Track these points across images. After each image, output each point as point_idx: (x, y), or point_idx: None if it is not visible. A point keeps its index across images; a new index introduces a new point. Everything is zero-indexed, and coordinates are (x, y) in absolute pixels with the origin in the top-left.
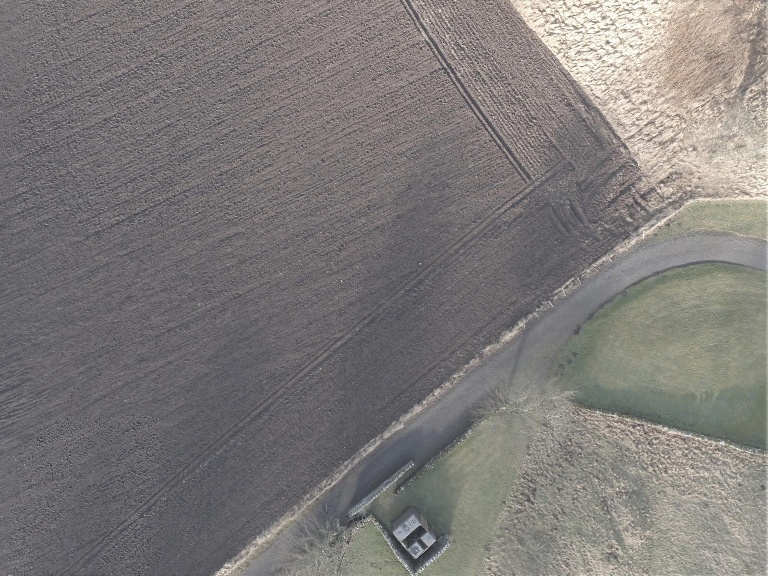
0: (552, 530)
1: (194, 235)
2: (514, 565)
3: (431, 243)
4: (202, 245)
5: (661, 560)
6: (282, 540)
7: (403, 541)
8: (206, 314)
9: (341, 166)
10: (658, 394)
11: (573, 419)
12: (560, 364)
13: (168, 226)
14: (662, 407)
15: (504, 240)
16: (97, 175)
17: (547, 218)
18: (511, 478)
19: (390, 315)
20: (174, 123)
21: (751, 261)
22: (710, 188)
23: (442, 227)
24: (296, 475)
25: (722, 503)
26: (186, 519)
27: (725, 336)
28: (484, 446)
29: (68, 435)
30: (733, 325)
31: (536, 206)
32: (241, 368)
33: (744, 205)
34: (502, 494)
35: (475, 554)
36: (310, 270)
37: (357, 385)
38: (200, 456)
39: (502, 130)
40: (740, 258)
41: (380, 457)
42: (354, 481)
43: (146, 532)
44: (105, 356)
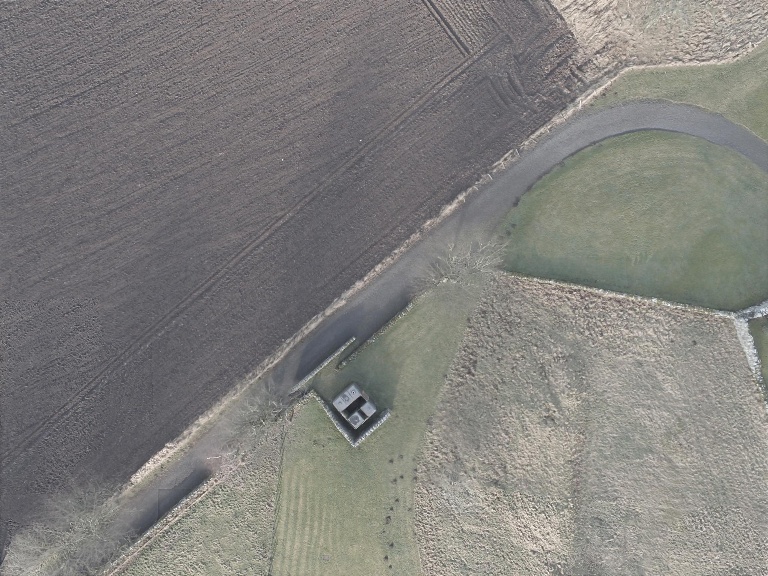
0: (492, 400)
1: (134, 116)
2: (456, 438)
3: (371, 119)
4: (142, 126)
5: (597, 422)
6: (225, 420)
7: (343, 412)
8: (147, 195)
9: (281, 44)
10: (594, 260)
11: (512, 289)
12: (499, 236)
13: (108, 107)
14: (598, 272)
15: (443, 114)
16: (35, 57)
17: (486, 91)
18: (452, 351)
19: (331, 193)
20: (113, 4)
21: (685, 127)
22: (644, 56)
23: (382, 103)
24: (238, 354)
25: (655, 361)
26: (128, 401)
27: (659, 199)
28: (425, 320)
29: (7, 318)
30: (667, 188)
31: (475, 80)
32: (182, 249)
33: (678, 72)
34: (443, 368)
35: (417, 428)
36: (251, 149)
37: (299, 263)
38: (142, 338)
39: (440, 4)
40: (674, 125)
41: (322, 335)
42: (297, 359)
43: (87, 415)
44: (44, 238)
